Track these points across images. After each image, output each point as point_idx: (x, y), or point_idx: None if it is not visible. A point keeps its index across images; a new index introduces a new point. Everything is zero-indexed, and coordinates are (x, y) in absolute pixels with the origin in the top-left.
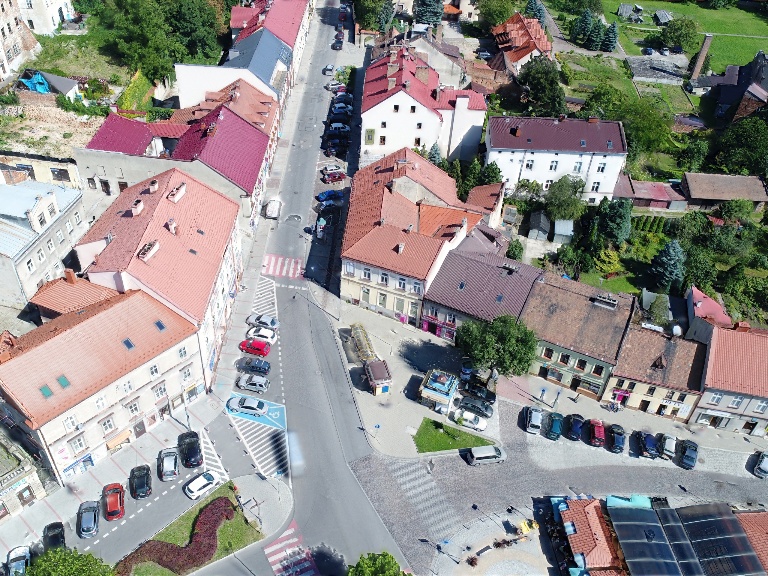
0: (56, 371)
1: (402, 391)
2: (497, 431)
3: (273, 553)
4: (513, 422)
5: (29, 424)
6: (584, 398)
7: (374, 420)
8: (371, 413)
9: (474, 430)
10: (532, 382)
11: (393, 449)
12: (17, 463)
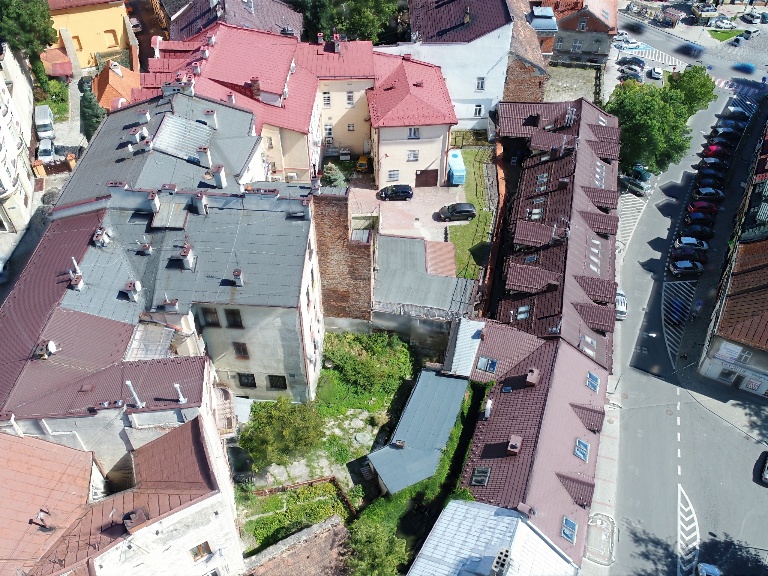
0: (599, 8)
1: (682, 24)
2: (741, 27)
3: (718, 85)
4: (742, 23)
5: (612, 33)
6: (758, 7)
7: (687, 36)
8: (682, 34)
9: (732, 29)
10: (729, 7)
11: (710, 43)
12: (594, 70)
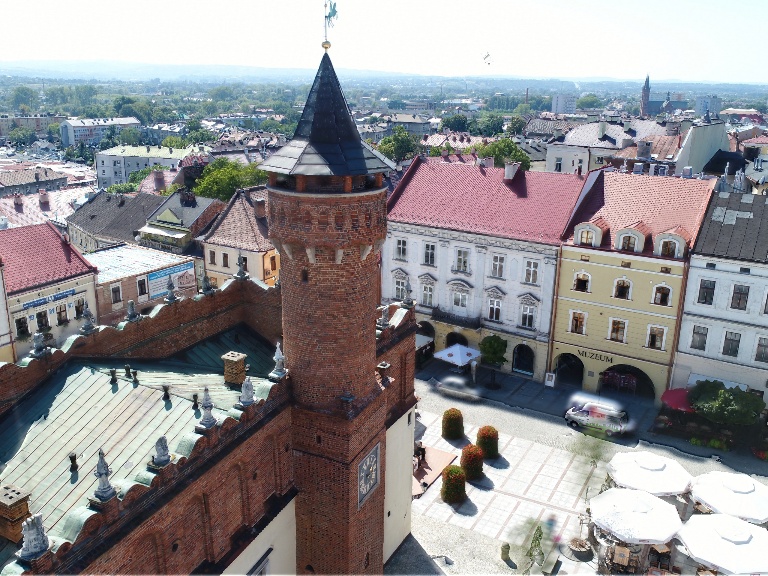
0: None
1: None
2: None
3: None
4: None
5: None
6: None
7: None
8: None
9: None
10: None
11: None
12: None
